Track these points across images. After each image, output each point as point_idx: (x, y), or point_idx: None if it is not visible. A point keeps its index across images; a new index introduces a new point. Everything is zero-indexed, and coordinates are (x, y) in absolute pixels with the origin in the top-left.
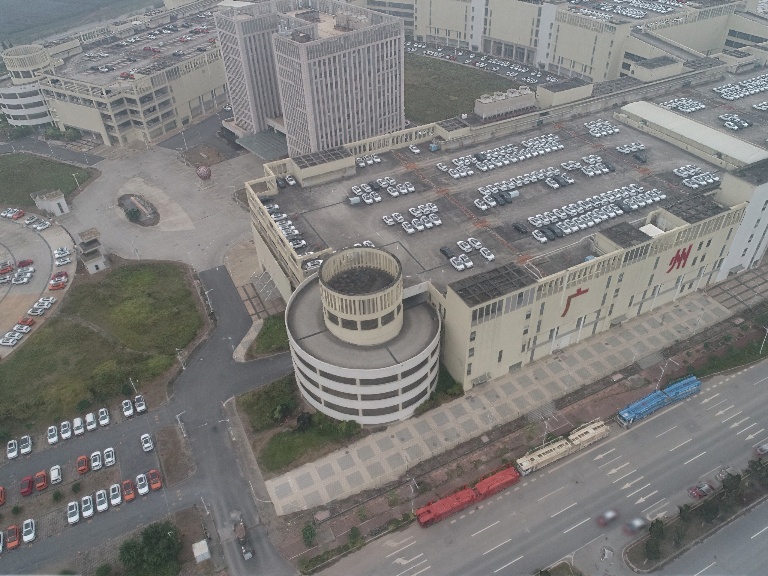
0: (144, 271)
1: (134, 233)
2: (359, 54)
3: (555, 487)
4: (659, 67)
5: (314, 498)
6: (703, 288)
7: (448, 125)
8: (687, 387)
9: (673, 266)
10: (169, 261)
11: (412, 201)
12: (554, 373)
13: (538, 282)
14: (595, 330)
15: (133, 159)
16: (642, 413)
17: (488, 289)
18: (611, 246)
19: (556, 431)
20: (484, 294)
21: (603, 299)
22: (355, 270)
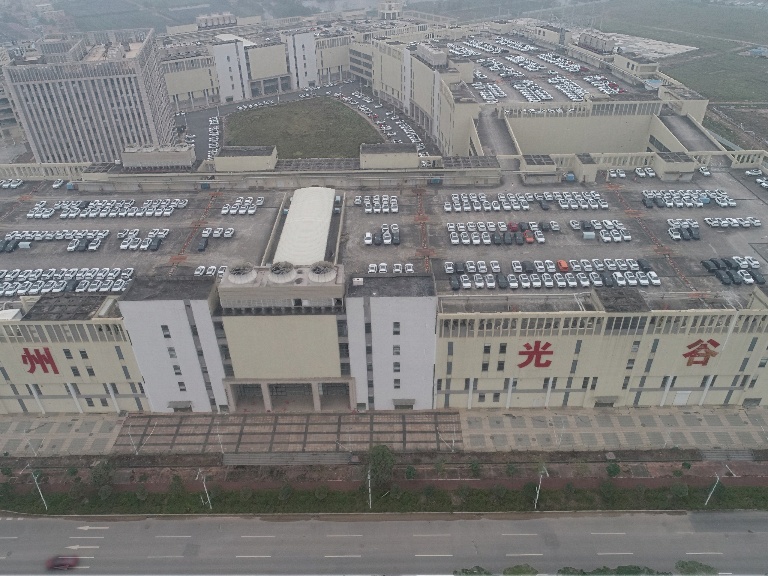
0: None
1: None
2: (81, 85)
3: None
4: None
5: None
6: (133, 412)
7: (96, 167)
8: None
9: (34, 367)
10: None
11: None
12: None
13: None
14: None
15: None
16: None
17: None
18: None
19: None
20: None
21: None
22: None
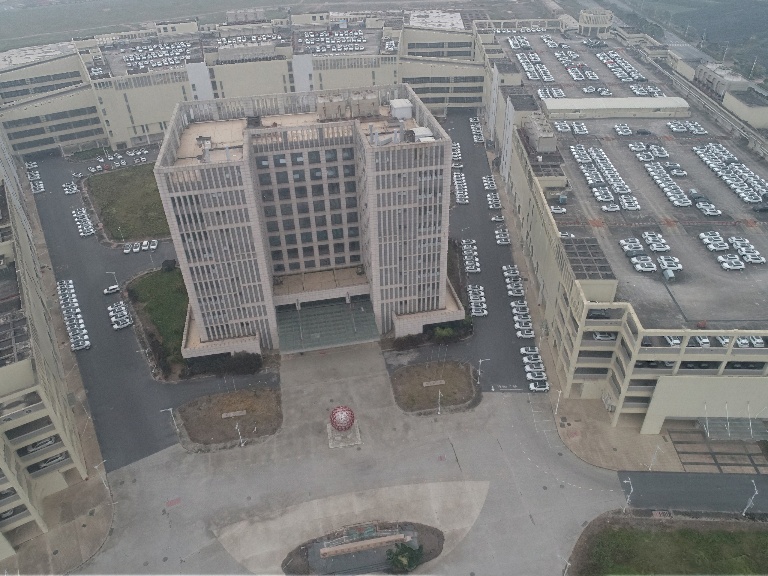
0: None
1: (456, 575)
2: None
3: None
4: None
5: None
6: None
7: (547, 172)
8: None
9: None
10: (582, 539)
11: (683, 244)
12: None
13: None
14: None
15: (130, 523)
16: None
17: None
18: None
19: None
20: None
21: None
22: None
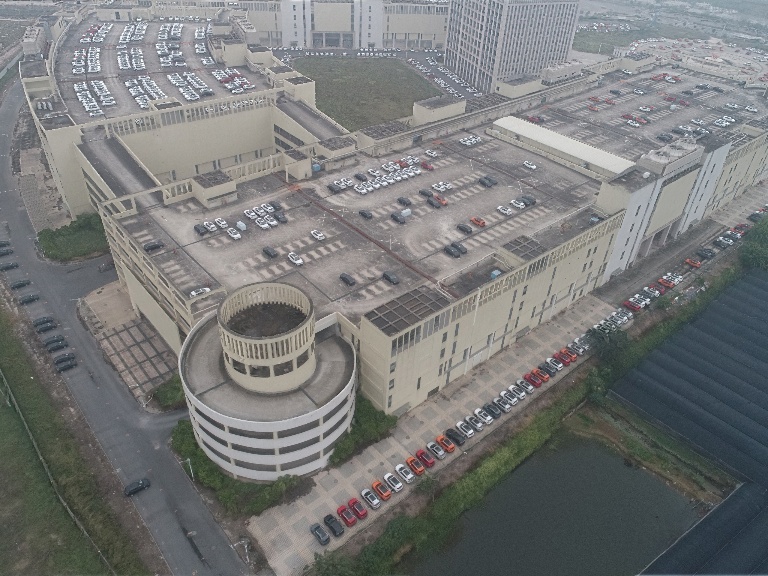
0: None
1: None
2: None
3: None
4: None
5: None
6: None
7: None
8: None
9: None
10: None
11: None
12: None
13: None
14: None
15: None
16: None
17: None
18: None
19: None
20: None
21: None
22: None
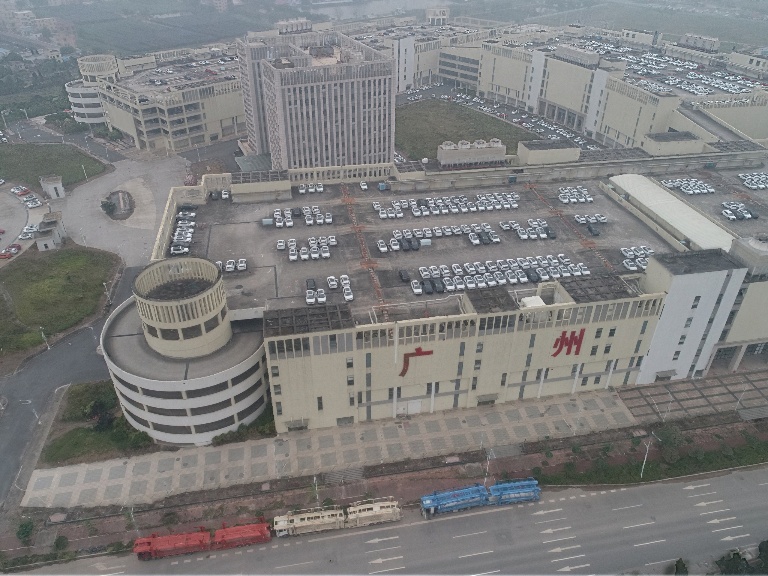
0: (81, 257)
1: (101, 224)
2: (341, 88)
3: (304, 559)
4: (670, 141)
5: (64, 498)
6: (618, 387)
7: (404, 167)
8: (518, 490)
9: (560, 350)
10: (110, 253)
11: (321, 232)
12: (385, 438)
13: (355, 328)
14: (458, 403)
15: (149, 163)
16: (453, 506)
17: (299, 324)
18: (471, 309)
19: (347, 500)
20: (291, 328)
21: (459, 368)
22: (193, 281)
